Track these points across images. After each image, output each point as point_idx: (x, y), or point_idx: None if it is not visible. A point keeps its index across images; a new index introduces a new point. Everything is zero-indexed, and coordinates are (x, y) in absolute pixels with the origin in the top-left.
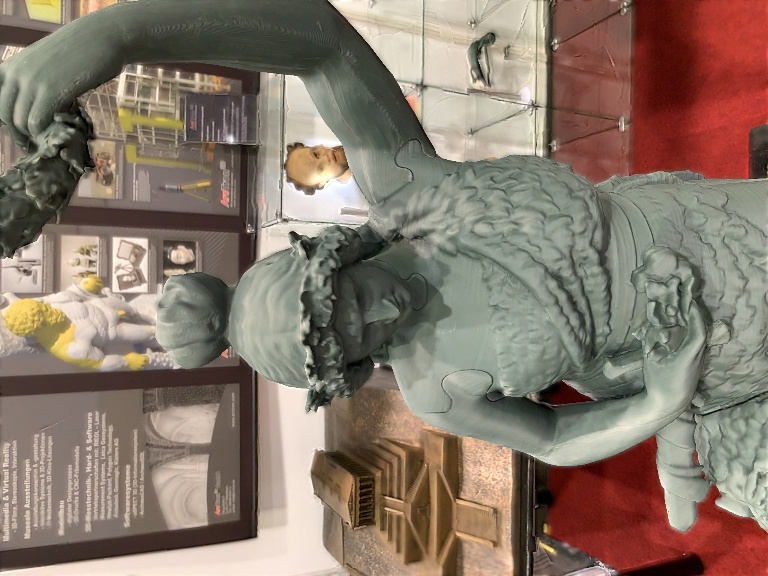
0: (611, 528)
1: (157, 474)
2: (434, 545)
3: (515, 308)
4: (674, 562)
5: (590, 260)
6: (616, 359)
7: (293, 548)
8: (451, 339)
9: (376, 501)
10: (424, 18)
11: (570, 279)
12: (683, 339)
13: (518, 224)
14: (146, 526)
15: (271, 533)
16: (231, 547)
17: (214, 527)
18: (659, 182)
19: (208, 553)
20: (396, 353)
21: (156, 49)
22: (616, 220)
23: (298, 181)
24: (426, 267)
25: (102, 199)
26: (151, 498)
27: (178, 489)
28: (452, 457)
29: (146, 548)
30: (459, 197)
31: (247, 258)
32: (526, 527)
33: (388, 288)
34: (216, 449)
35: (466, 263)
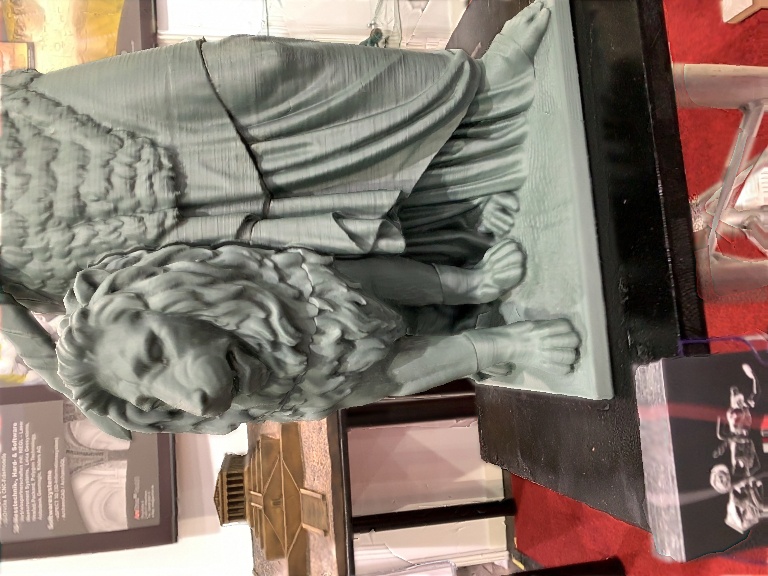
0: (558, 536)
1: (76, 479)
2: (285, 539)
3: None
4: (592, 567)
5: None
6: None
7: (228, 557)
8: None
9: (246, 497)
10: (268, 23)
11: None
12: None
13: None
14: (67, 528)
15: (204, 541)
16: (152, 552)
17: (133, 531)
18: None
19: (130, 557)
20: None
21: None
22: None
23: None
24: None
25: None
26: (70, 502)
27: (97, 494)
28: (293, 445)
29: (71, 550)
30: None
31: None
32: None
33: None
34: (135, 456)
35: None
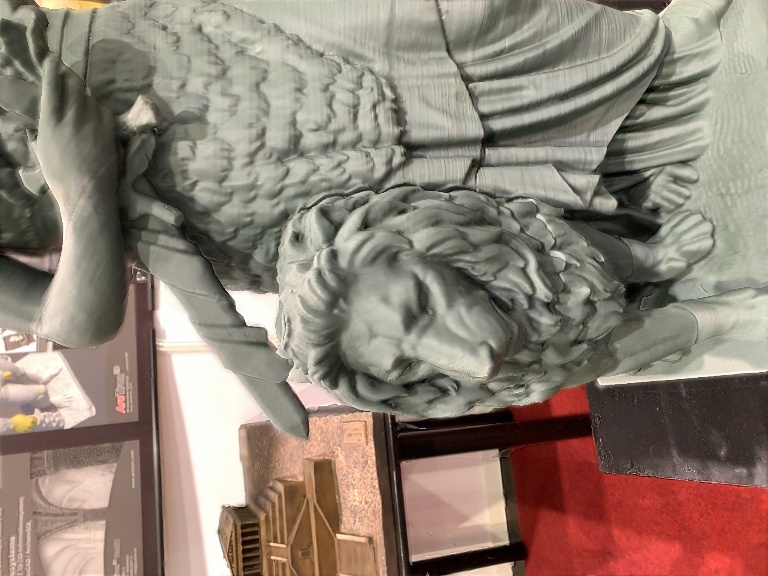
0: (584, 575)
1: (44, 545)
2: None
3: None
4: None
5: None
6: None
7: None
8: None
9: (263, 550)
10: None
11: None
12: (37, 99)
13: None
14: None
15: None
16: None
17: None
18: None
19: None
20: None
21: None
22: None
23: None
24: None
25: None
26: (37, 573)
27: (70, 562)
28: (327, 484)
29: None
30: None
31: (145, 309)
32: (400, 554)
33: None
34: (115, 514)
35: None
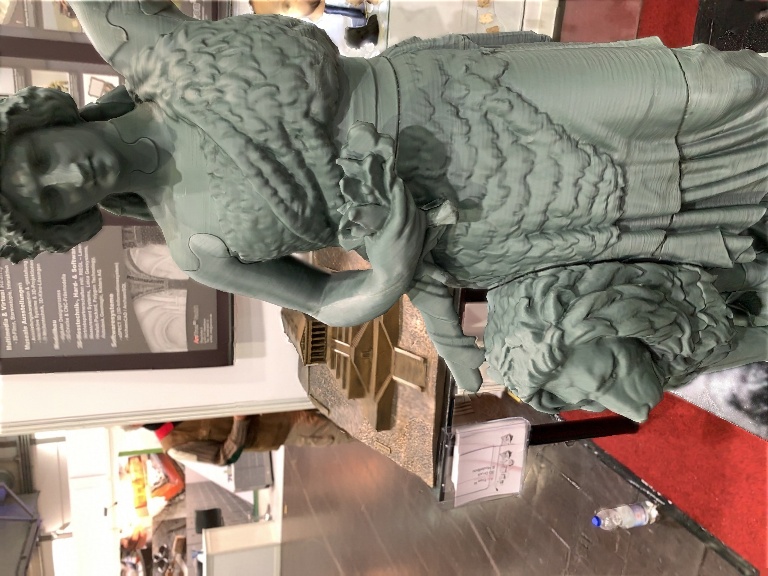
0: None
1: (138, 304)
2: (373, 385)
3: (228, 177)
4: (612, 420)
5: (306, 132)
6: (349, 232)
7: (271, 377)
8: (185, 203)
9: (328, 343)
10: None
11: (280, 151)
12: (385, 217)
13: (222, 92)
14: (131, 348)
15: (250, 363)
16: (209, 371)
17: (193, 353)
18: (446, 46)
19: (189, 375)
20: (153, 213)
21: None
22: (361, 89)
23: None
24: (158, 131)
25: (68, 32)
26: (134, 324)
27: (159, 318)
28: (393, 309)
29: (133, 366)
30: (169, 60)
31: None
32: (449, 377)
33: (83, 152)
34: (194, 286)
35: (187, 129)
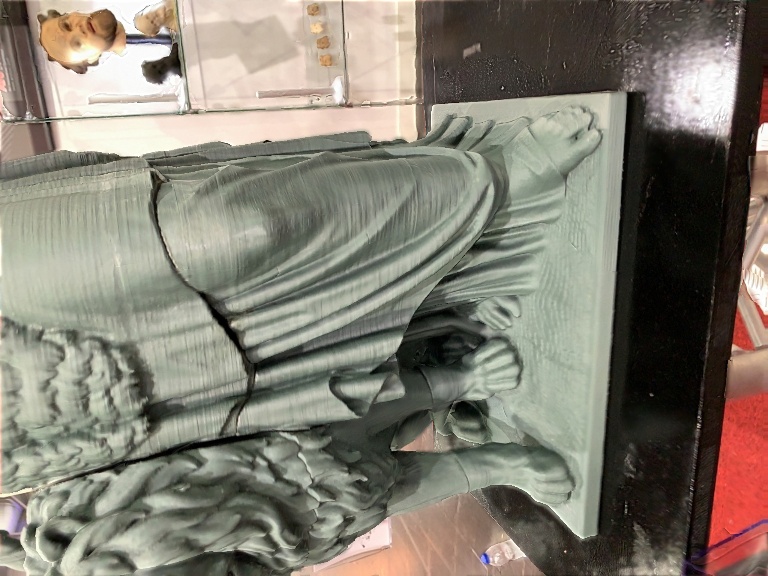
0: None
1: None
2: None
3: None
4: None
5: None
6: None
7: None
8: None
9: None
10: None
11: None
12: None
13: None
14: None
15: None
16: None
17: None
18: None
19: None
20: None
21: None
22: None
23: (58, 59)
24: None
25: None
26: None
27: None
28: None
29: None
30: None
31: (44, 148)
32: None
33: None
34: None
35: None
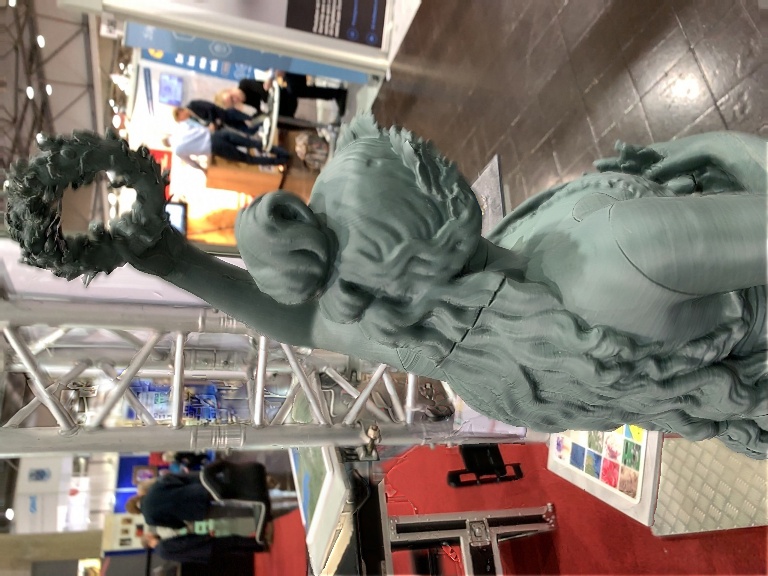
0: None
1: None
2: None
3: None
4: None
5: None
6: None
7: None
8: None
9: None
10: None
11: None
12: None
13: None
14: None
15: None
16: None
17: None
18: None
19: None
20: (534, 267)
21: (204, 257)
22: None
23: None
24: None
25: None
26: None
27: None
28: None
29: None
30: None
31: None
32: None
33: None
34: None
35: None
